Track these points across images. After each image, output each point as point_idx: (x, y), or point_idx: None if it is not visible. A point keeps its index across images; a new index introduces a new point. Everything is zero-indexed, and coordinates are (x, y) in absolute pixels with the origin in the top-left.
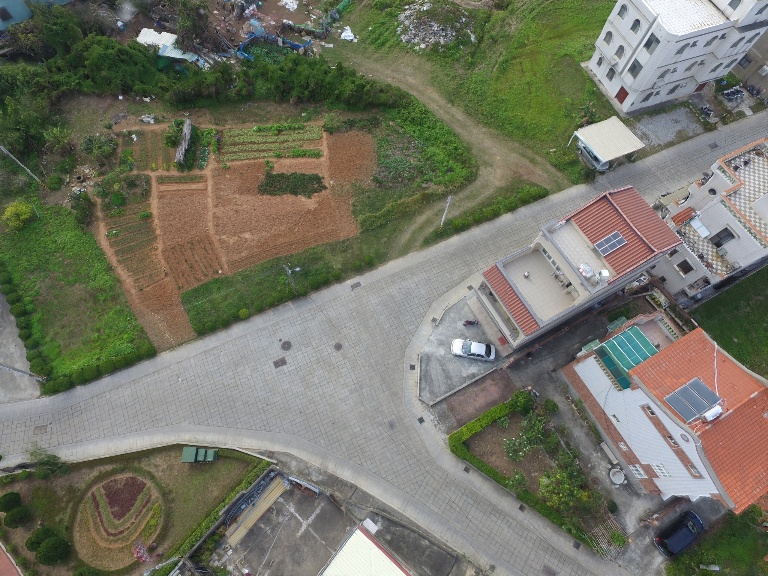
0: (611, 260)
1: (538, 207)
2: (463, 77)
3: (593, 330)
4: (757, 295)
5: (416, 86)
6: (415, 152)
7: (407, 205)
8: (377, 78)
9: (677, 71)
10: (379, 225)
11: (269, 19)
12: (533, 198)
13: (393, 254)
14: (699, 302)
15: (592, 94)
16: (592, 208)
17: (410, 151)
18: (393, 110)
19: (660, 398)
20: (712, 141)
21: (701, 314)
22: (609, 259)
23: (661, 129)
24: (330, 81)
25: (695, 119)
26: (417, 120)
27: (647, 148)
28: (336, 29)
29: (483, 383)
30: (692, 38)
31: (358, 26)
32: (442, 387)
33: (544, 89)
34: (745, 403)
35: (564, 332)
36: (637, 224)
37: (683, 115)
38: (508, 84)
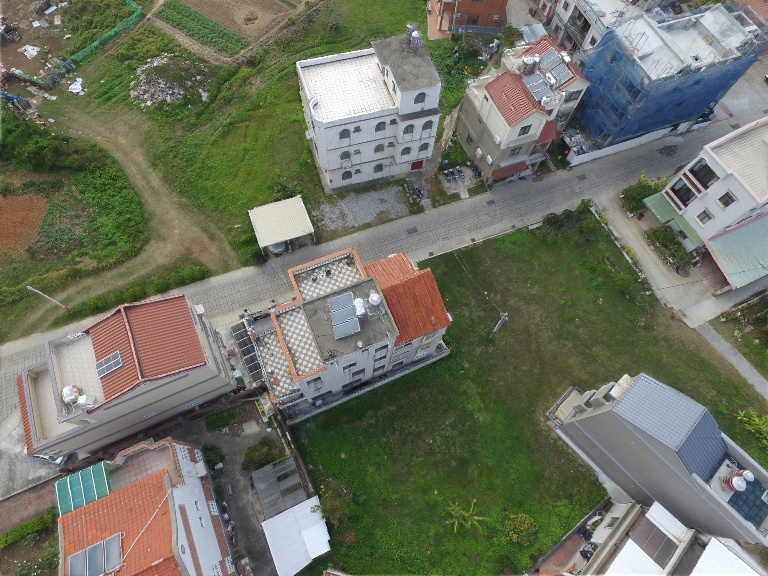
0: (104, 383)
1: (193, 290)
2: (178, 139)
3: (186, 436)
4: (389, 405)
5: (123, 147)
6: (85, 221)
7: (49, 280)
8: (86, 136)
9: (363, 152)
10: (11, 301)
11: (1, 66)
12: (189, 280)
13: (14, 334)
14: (308, 412)
15: (304, 166)
16: (108, 321)
17: (80, 220)
18: (80, 173)
19: (68, 555)
20: (413, 225)
21: (317, 423)
22: (103, 382)
23: (362, 209)
24: (11, 141)
25: (404, 200)
26: (98, 186)
27: (338, 229)
28: (67, 80)
29: (43, 489)
30: (346, 124)
31: (91, 78)
32: (0, 490)
33: (259, 157)
34: (143, 571)
35: (144, 438)
36: (144, 344)
37: (393, 194)
38: (223, 149)
